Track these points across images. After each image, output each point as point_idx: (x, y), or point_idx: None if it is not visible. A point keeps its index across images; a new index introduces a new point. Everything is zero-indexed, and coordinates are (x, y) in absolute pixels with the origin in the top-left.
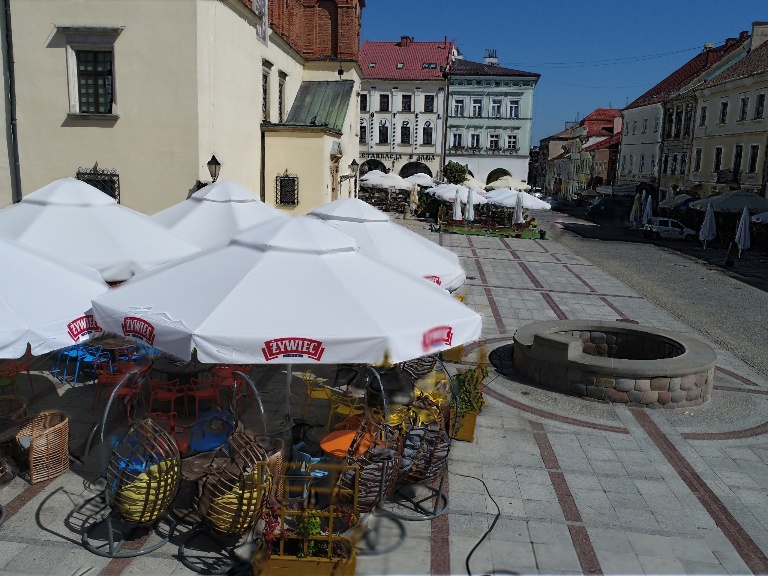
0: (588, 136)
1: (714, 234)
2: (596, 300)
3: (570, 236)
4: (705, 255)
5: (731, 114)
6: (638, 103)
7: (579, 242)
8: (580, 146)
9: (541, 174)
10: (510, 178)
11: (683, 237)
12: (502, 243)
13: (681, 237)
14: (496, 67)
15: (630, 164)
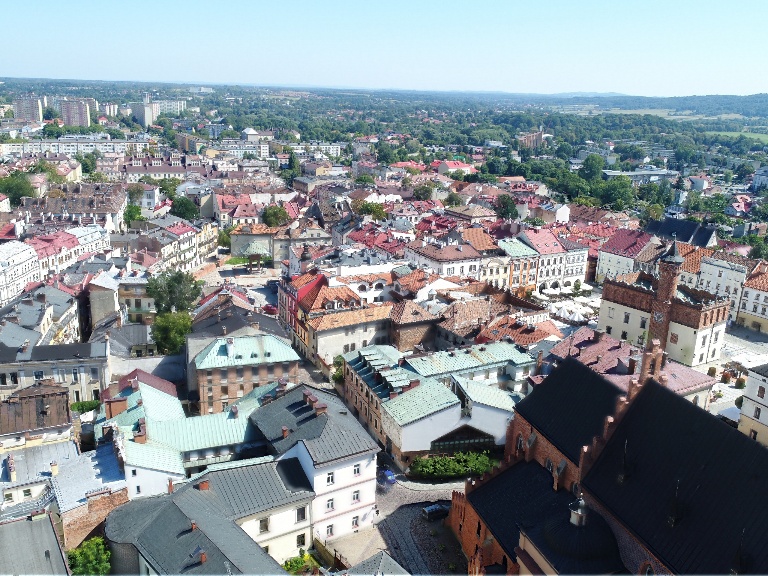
0: None
1: None
2: None
3: None
4: None
5: None
6: None
7: None
8: None
9: None
10: None
11: None
12: None
13: None
14: (572, 241)
15: (608, 271)
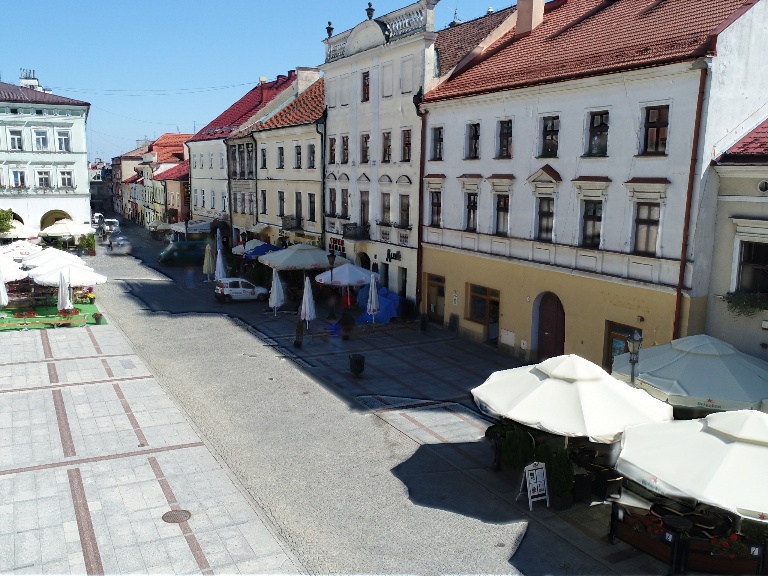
0: (158, 163)
1: (282, 300)
2: (143, 469)
3: (134, 310)
4: (276, 328)
5: (287, 160)
6: (202, 135)
7: (143, 323)
8: (151, 173)
9: (117, 195)
10: (68, 222)
11: (255, 297)
12: (41, 345)
13: (253, 297)
14: (35, 91)
15: (202, 198)
